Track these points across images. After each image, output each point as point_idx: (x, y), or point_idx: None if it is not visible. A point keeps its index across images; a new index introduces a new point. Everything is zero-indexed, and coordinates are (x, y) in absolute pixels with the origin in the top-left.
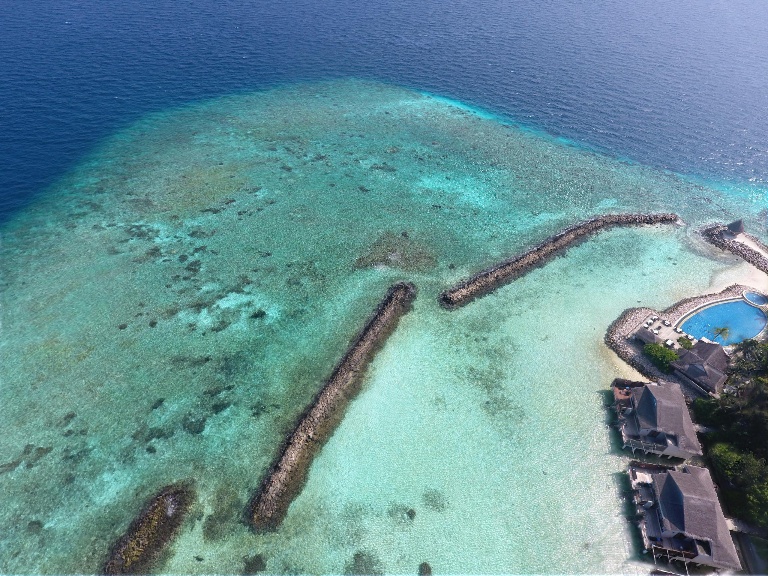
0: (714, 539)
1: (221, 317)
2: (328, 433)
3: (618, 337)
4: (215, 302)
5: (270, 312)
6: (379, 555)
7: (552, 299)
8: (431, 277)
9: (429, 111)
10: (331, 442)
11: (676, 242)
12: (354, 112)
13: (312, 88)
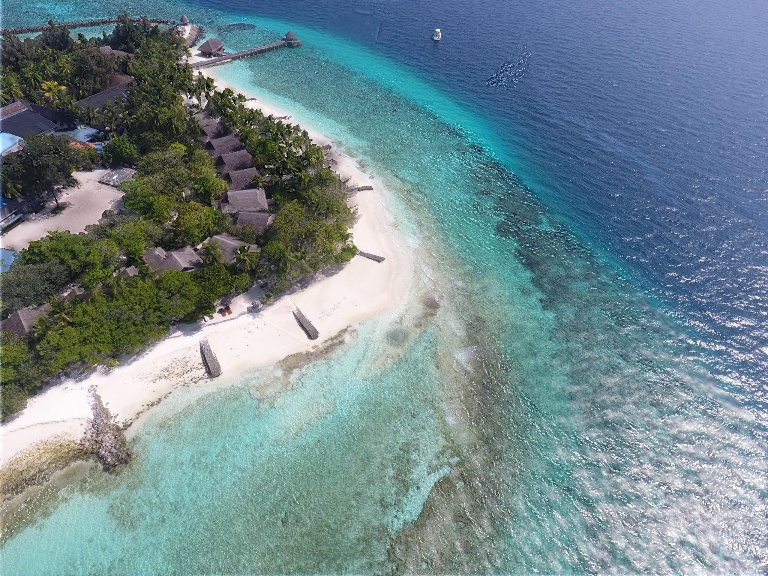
0: None
1: None
2: None
3: None
4: None
5: None
6: None
7: None
8: None
9: None
10: None
11: None
12: None
13: None
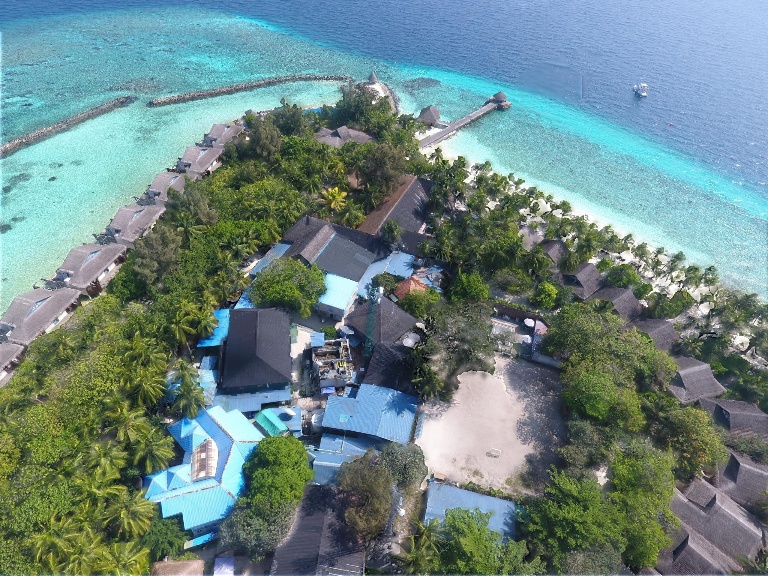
0: (193, 162)
1: (3, 105)
2: (36, 142)
3: (240, 117)
4: (4, 99)
5: (36, 104)
6: (33, 174)
7: (221, 106)
8: (152, 96)
9: (231, 25)
10: (36, 145)
11: (334, 88)
12: (173, 23)
13: (152, 10)
